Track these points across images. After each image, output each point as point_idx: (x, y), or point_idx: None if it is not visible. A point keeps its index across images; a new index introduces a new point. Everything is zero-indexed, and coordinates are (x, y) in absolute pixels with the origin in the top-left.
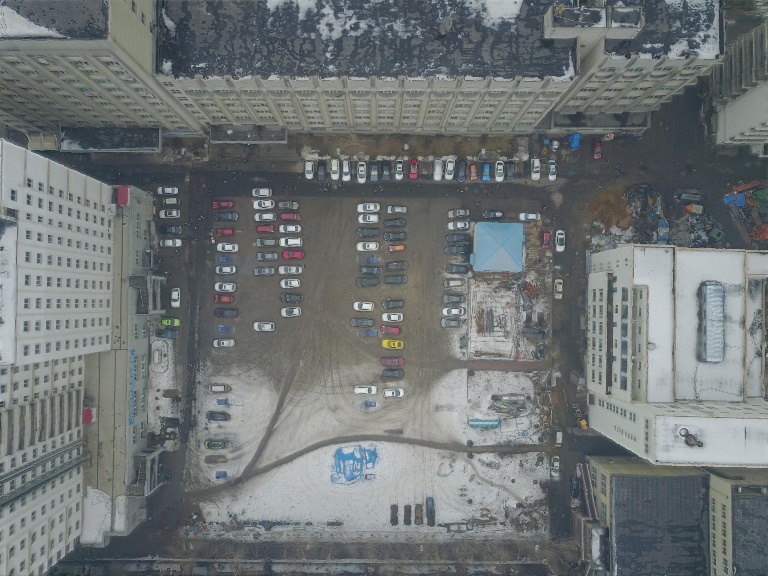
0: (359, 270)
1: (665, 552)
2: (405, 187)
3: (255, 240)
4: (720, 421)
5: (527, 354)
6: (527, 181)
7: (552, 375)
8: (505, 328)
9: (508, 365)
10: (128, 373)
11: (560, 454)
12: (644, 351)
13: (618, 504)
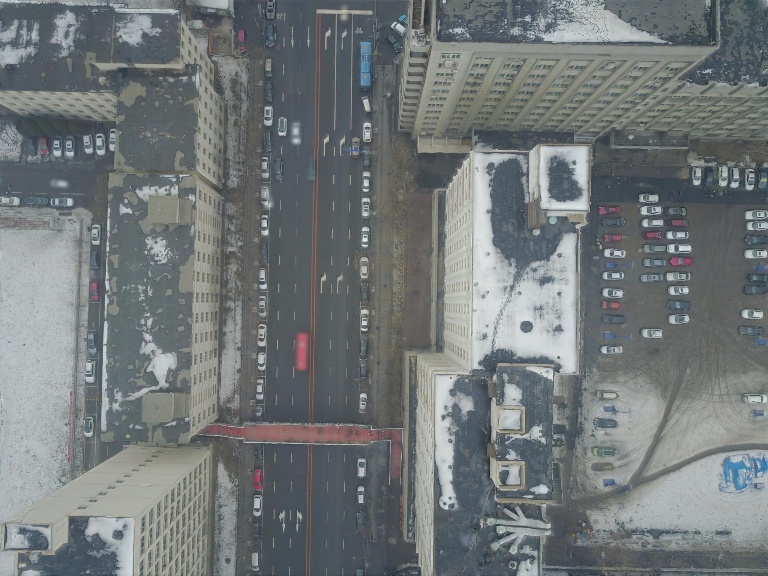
0: (747, 278)
1: None
2: None
3: (641, 246)
4: None
5: None
6: None
7: None
8: None
9: None
10: None
11: None
12: None
13: None
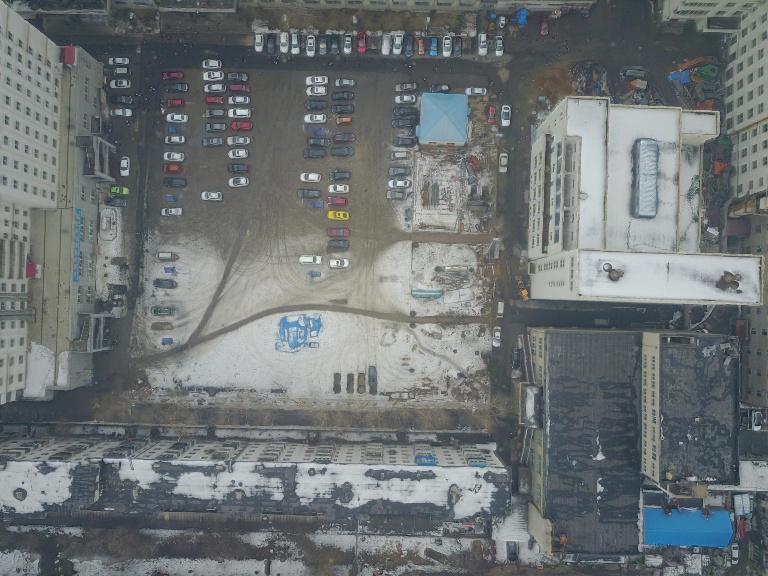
0: (307, 142)
1: (597, 407)
2: (354, 61)
3: (204, 111)
4: (643, 256)
5: (471, 227)
6: (474, 57)
7: (495, 247)
8: (450, 201)
9: (452, 238)
10: (73, 230)
11: (502, 325)
12: (576, 201)
13: (552, 361)
